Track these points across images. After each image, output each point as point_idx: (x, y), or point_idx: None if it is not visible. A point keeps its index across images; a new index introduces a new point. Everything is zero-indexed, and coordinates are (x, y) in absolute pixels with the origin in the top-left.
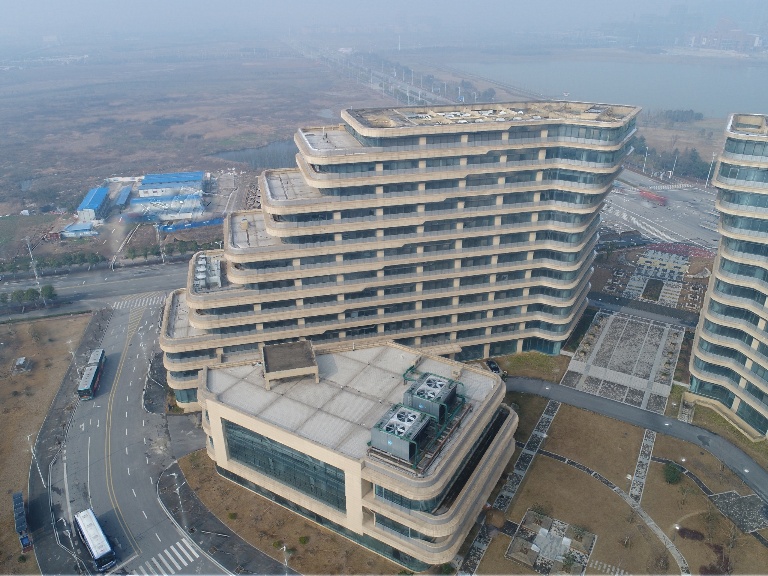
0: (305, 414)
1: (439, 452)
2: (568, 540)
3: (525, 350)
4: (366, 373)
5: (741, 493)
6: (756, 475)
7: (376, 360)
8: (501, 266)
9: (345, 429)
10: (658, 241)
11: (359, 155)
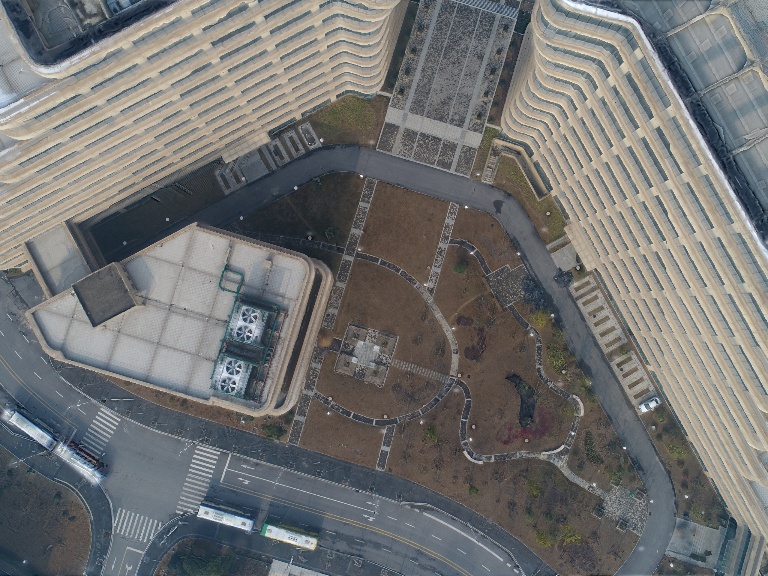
0: (148, 353)
1: (268, 374)
2: (378, 348)
3: (340, 96)
4: (184, 281)
5: (512, 267)
6: (529, 242)
7: (188, 257)
8: (290, 70)
9: (188, 364)
10: None
11: (48, 101)
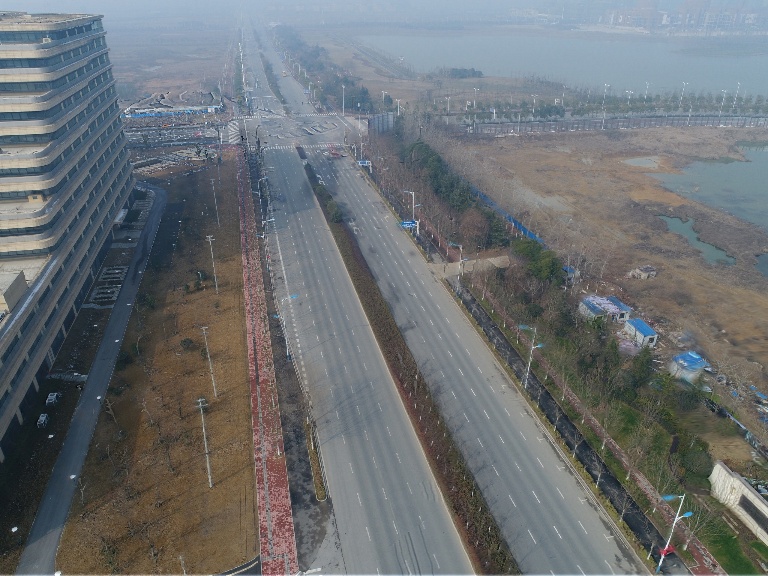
0: None
1: None
2: None
3: None
4: None
5: None
6: None
7: None
8: None
9: None
10: (222, 143)
11: None
